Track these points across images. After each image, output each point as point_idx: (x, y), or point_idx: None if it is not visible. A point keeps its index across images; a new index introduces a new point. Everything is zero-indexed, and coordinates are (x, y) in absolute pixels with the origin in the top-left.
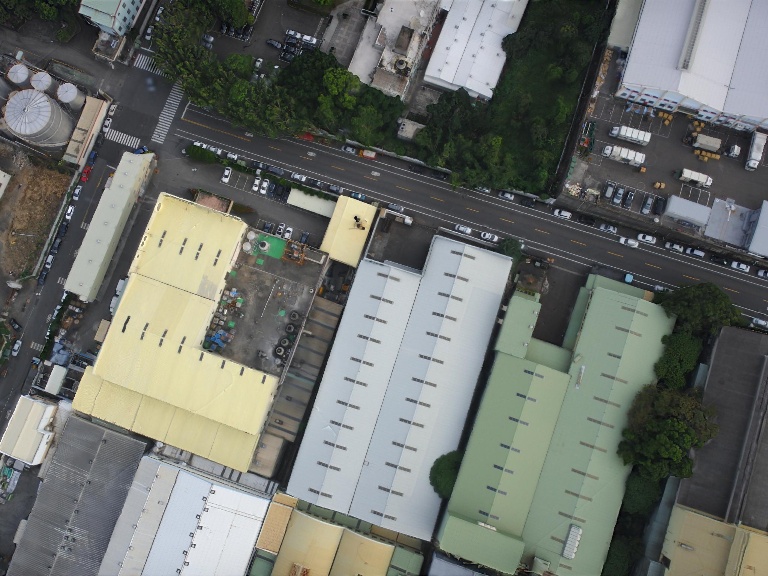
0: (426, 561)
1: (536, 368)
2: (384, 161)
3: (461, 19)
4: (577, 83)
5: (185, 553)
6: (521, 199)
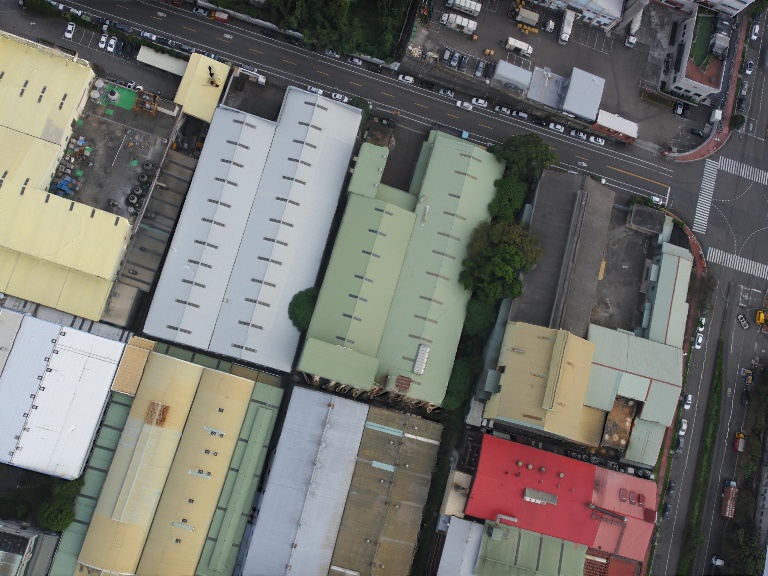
0: (286, 396)
1: (386, 206)
2: (236, 25)
3: None
4: None
5: (33, 396)
6: (368, 65)
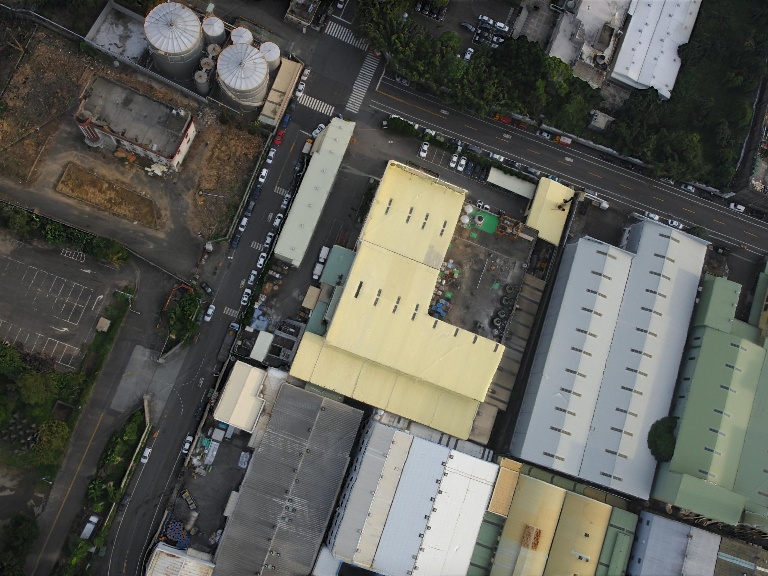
0: None
1: (741, 342)
2: (576, 148)
3: (644, 24)
4: (751, 92)
5: (428, 517)
6: (700, 192)
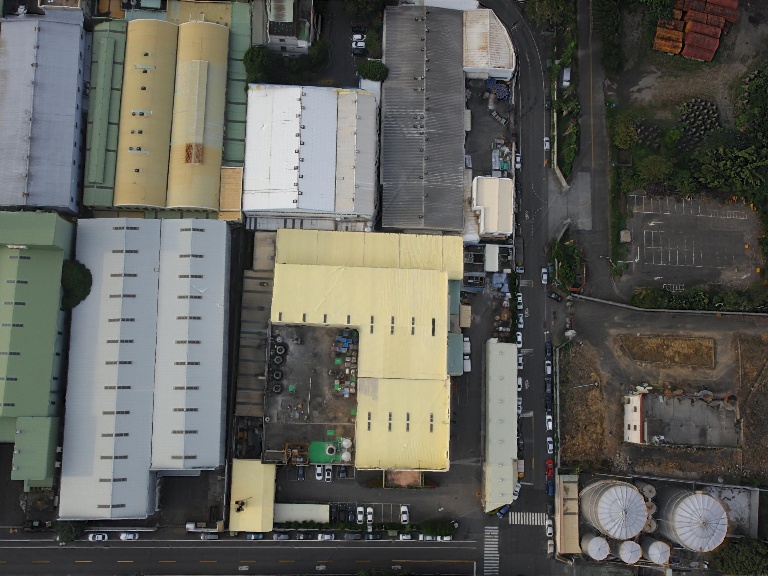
0: None
1: (2, 411)
2: None
3: None
4: None
5: (302, 143)
6: None
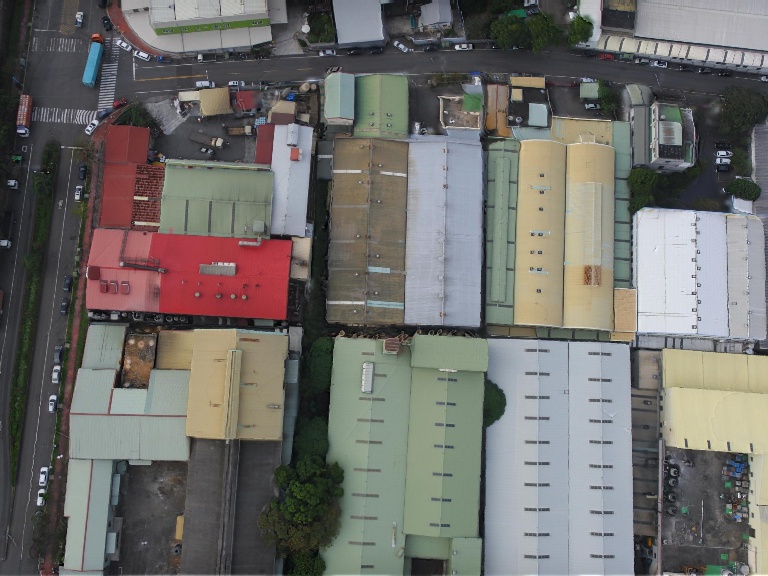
0: None
1: (440, 532)
2: None
3: None
4: None
5: (699, 269)
6: None
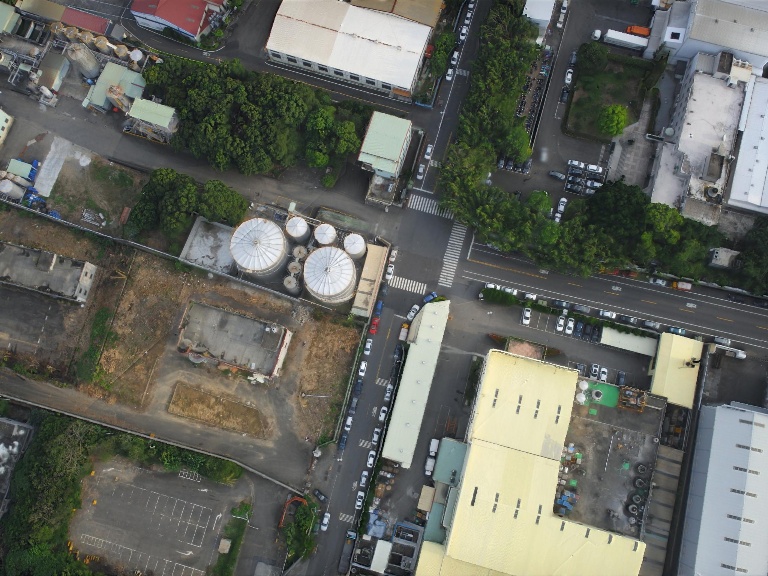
0: None
1: None
2: (698, 291)
3: (759, 139)
4: None
5: None
6: None
